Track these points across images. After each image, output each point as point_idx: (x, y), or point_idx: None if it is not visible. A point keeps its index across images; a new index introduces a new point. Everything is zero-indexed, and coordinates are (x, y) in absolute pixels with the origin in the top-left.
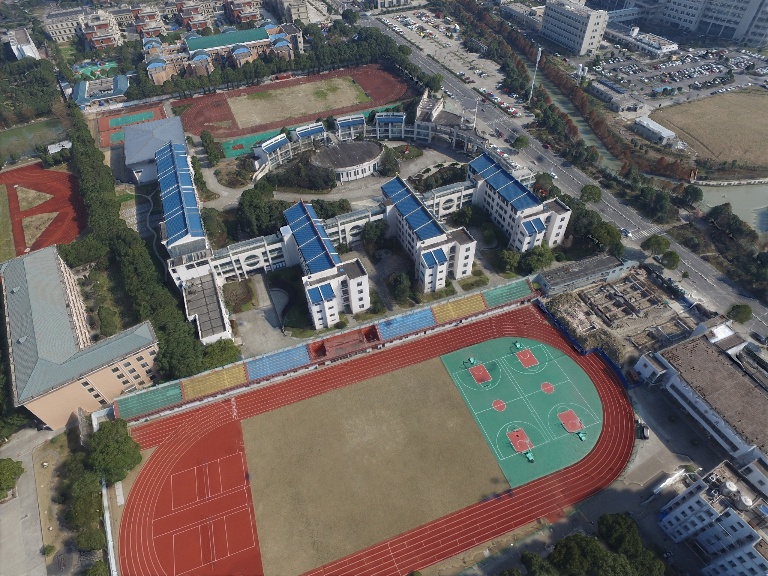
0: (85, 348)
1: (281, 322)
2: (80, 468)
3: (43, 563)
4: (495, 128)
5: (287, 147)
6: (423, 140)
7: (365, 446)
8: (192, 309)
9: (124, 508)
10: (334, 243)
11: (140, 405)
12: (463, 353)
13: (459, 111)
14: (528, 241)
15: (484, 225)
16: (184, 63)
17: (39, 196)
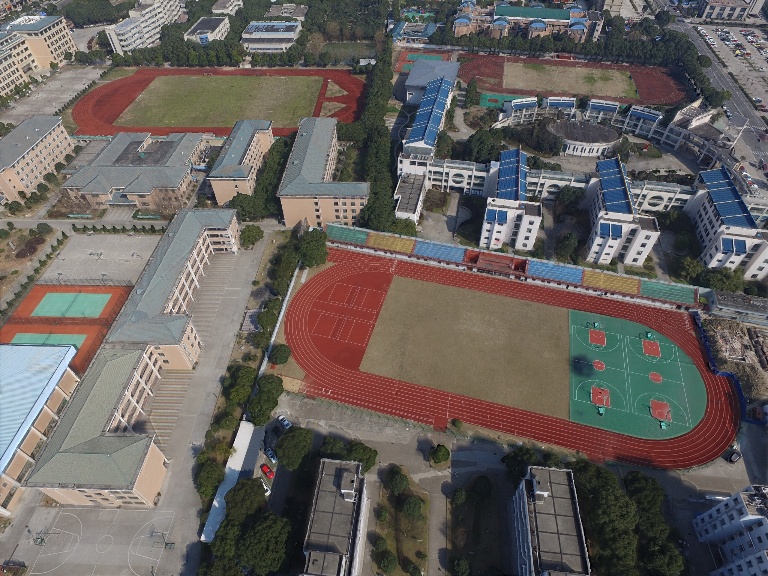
0: (326, 182)
1: (456, 230)
2: (292, 248)
3: (251, 288)
4: (760, 158)
5: (533, 110)
6: (669, 146)
7: (470, 333)
8: (400, 192)
9: (303, 285)
10: (530, 193)
11: (339, 234)
12: (592, 316)
13: (729, 133)
14: (720, 258)
15: (683, 232)
16: (485, 24)
17: (340, 91)
